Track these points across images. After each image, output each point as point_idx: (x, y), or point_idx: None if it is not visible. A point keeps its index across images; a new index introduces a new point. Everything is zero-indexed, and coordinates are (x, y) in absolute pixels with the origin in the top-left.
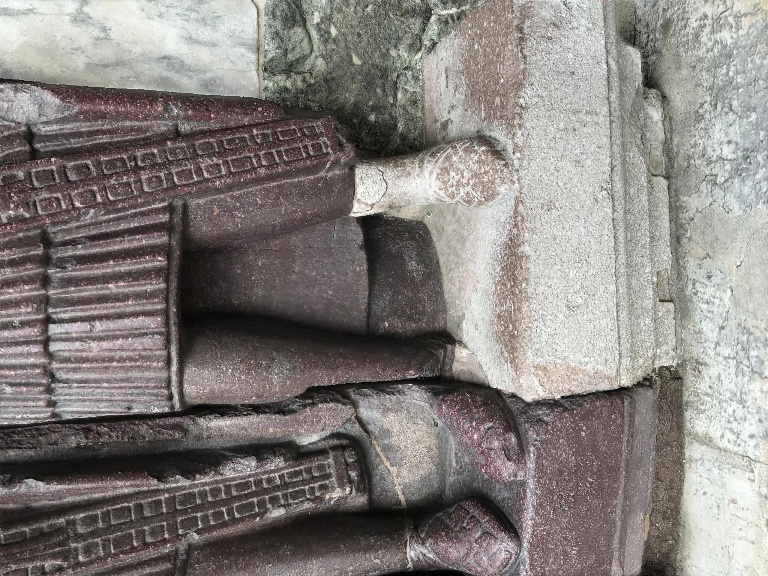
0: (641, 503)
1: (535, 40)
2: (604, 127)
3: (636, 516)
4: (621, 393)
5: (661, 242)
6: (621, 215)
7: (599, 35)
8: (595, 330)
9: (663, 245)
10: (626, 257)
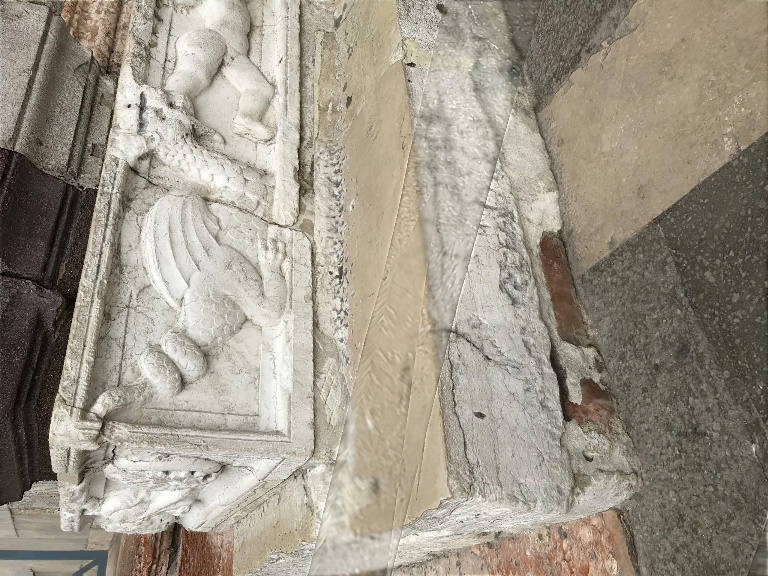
0: (43, 237)
1: (3, 18)
2: (34, 51)
3: (36, 241)
4: (12, 151)
5: (99, 132)
6: (38, 86)
7: (42, 22)
8: (1, 121)
9: (100, 133)
10: (38, 104)
